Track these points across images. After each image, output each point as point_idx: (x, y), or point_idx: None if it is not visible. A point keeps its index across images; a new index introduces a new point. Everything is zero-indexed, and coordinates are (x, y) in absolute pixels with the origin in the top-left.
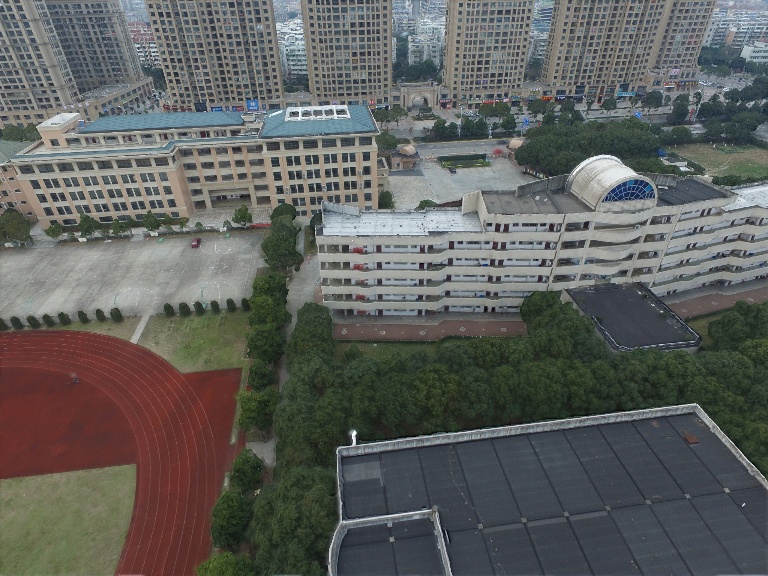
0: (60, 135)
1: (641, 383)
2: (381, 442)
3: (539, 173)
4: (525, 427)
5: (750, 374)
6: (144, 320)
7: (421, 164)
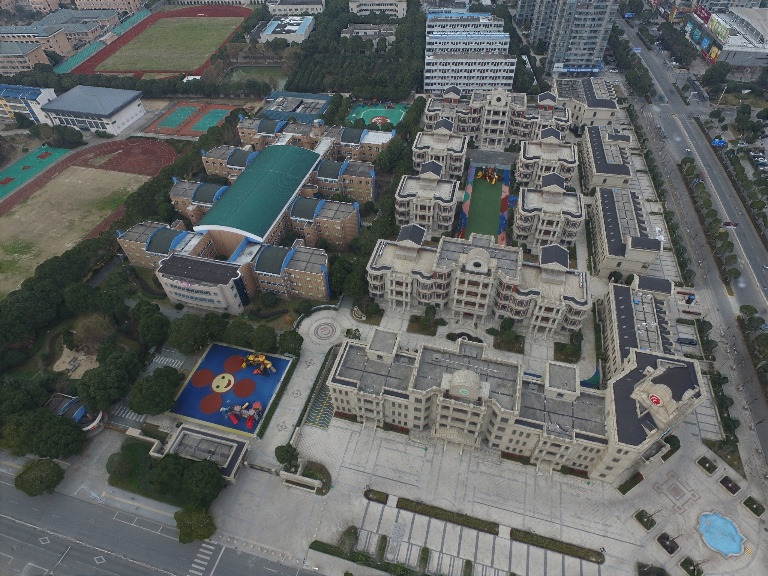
0: None
1: None
2: None
3: None
4: None
5: None
6: None
7: None
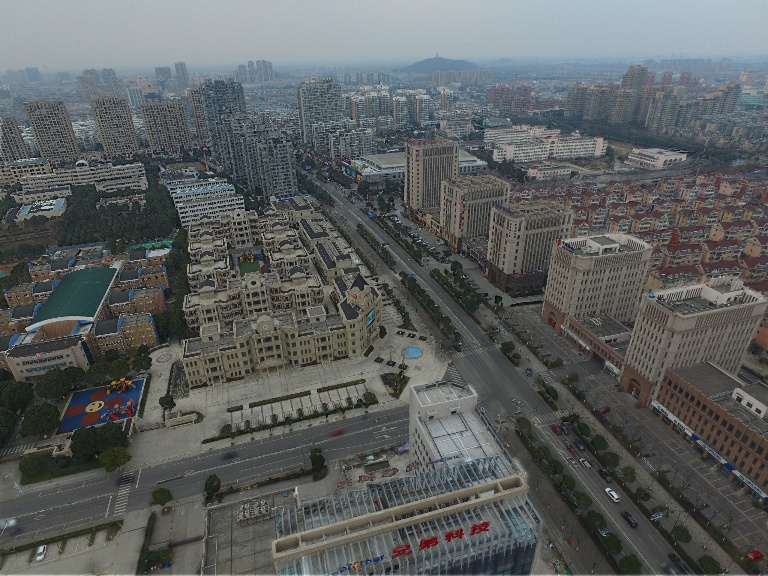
0: None
1: (73, 189)
2: (21, 191)
3: None
4: None
5: None
6: None
7: None
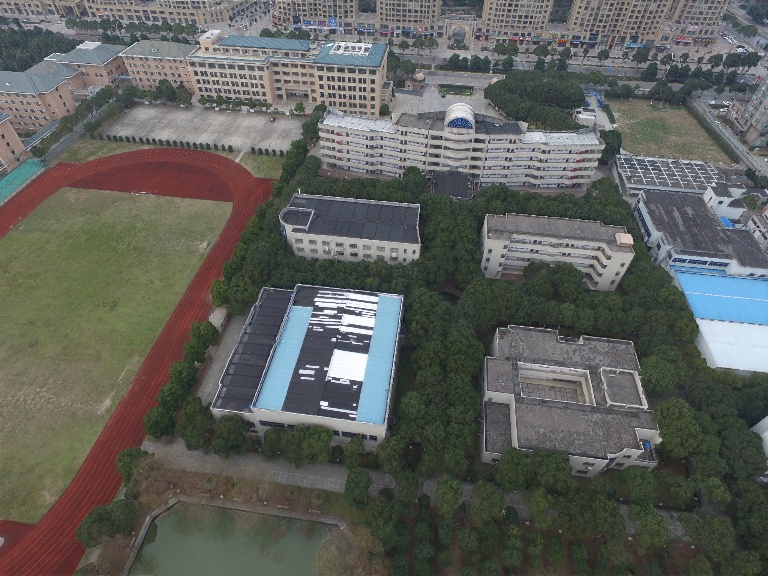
0: (210, 45)
1: (422, 204)
2: (308, 195)
3: (495, 106)
4: (356, 200)
5: (462, 206)
6: (242, 153)
7: (427, 87)
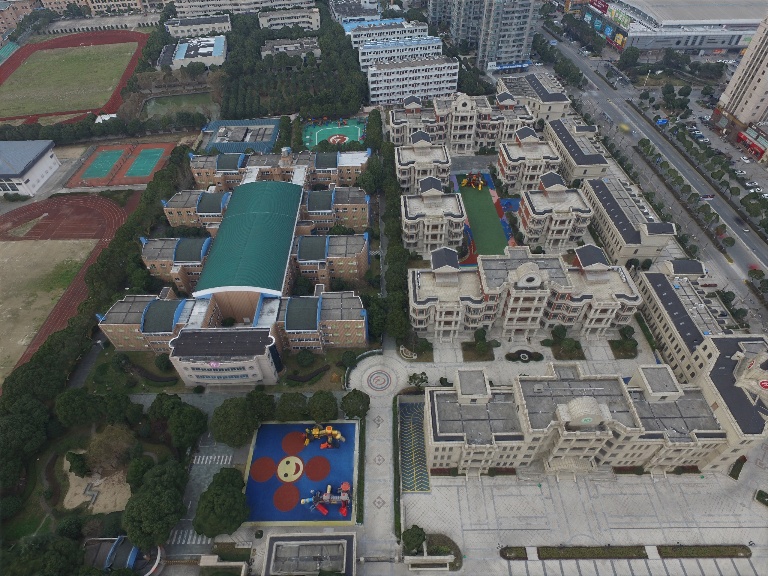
0: None
1: (232, 19)
2: None
3: None
4: None
5: None
6: (133, 28)
7: None
